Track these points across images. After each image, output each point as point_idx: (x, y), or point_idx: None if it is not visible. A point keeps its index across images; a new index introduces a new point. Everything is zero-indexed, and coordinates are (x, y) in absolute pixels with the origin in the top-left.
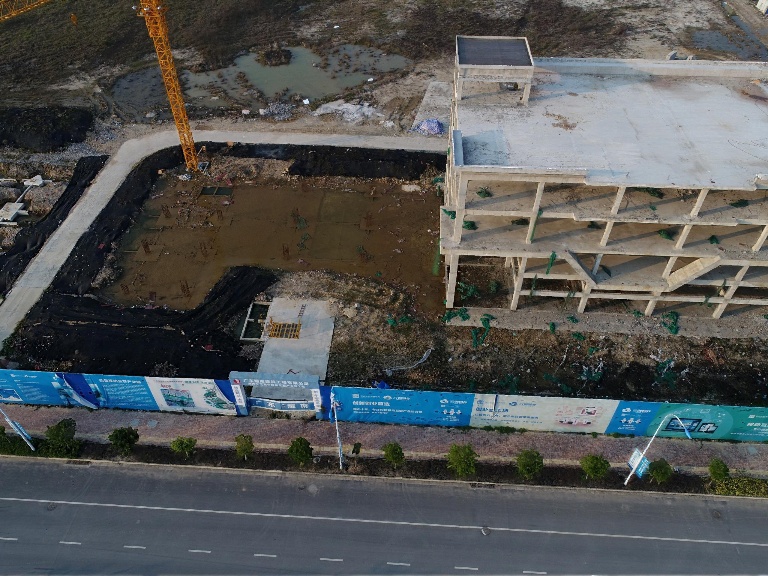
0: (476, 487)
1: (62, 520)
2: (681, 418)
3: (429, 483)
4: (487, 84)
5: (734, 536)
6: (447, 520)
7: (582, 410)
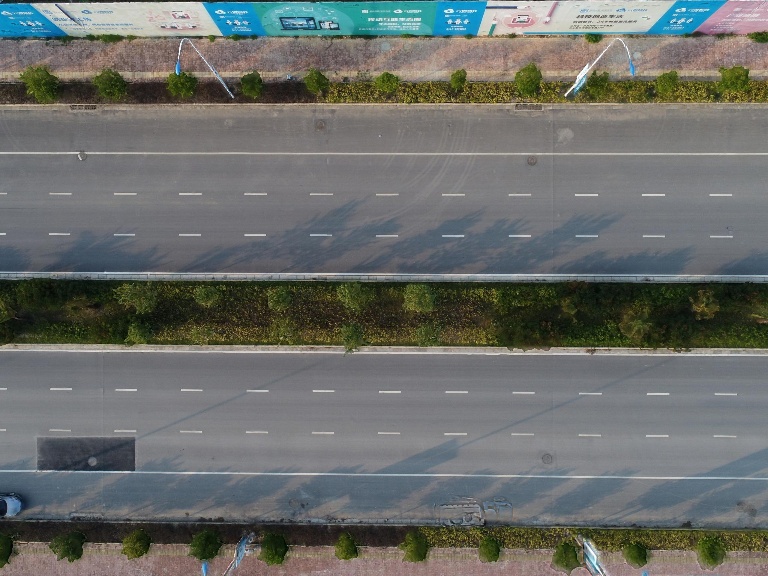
0: (76, 110)
1: None
2: (289, 17)
3: (27, 108)
4: None
5: (330, 146)
6: (44, 147)
7: (171, 14)
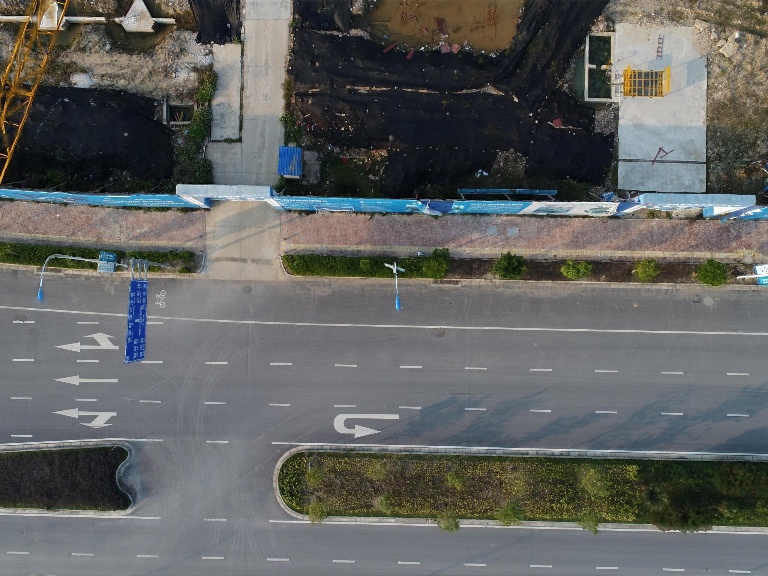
0: None
1: (458, 346)
2: None
3: None
4: None
5: None
6: None
7: None
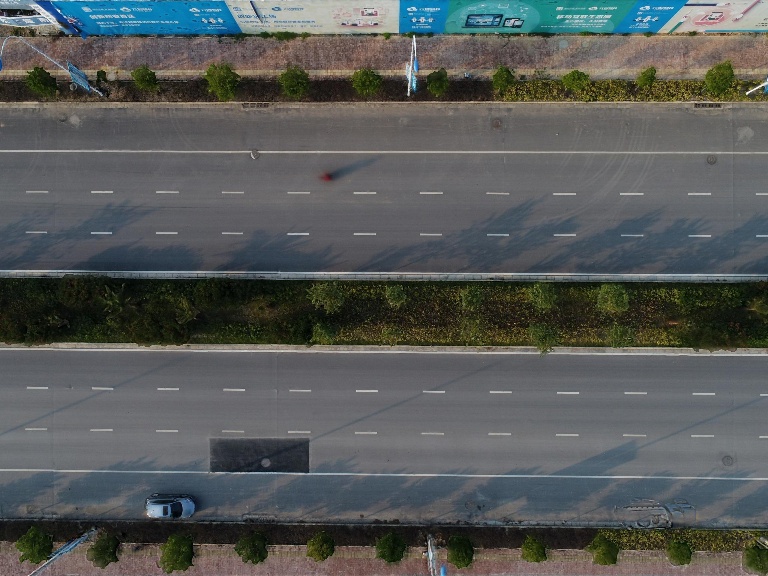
0: (248, 108)
1: None
2: (479, 14)
3: (198, 106)
4: None
5: (506, 145)
6: (216, 146)
7: (361, 11)
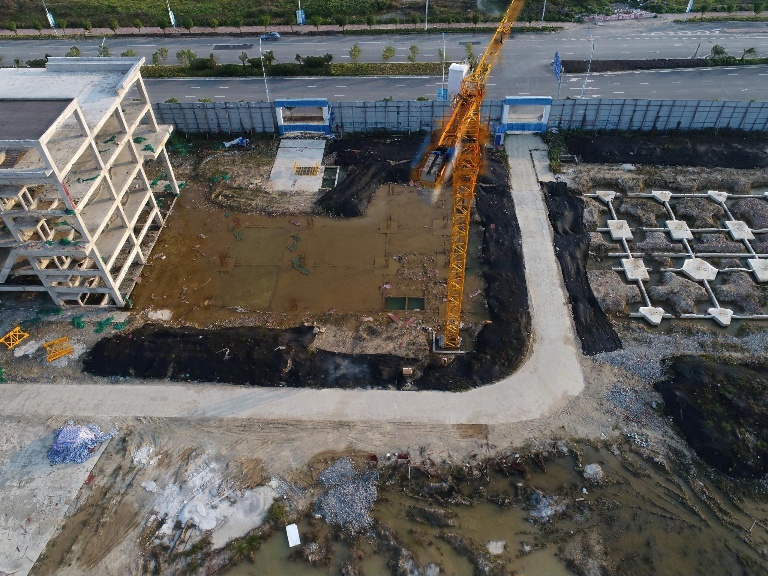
0: None
1: None
2: None
3: None
4: (38, 155)
5: None
6: None
7: None
